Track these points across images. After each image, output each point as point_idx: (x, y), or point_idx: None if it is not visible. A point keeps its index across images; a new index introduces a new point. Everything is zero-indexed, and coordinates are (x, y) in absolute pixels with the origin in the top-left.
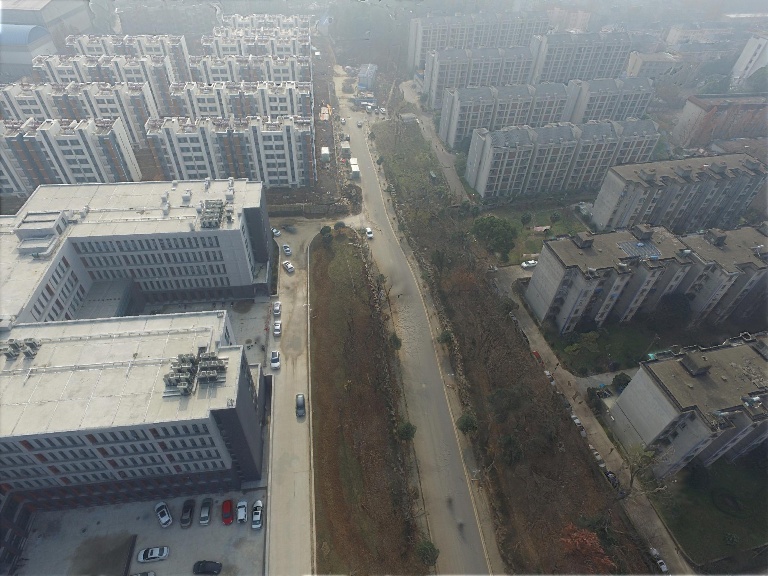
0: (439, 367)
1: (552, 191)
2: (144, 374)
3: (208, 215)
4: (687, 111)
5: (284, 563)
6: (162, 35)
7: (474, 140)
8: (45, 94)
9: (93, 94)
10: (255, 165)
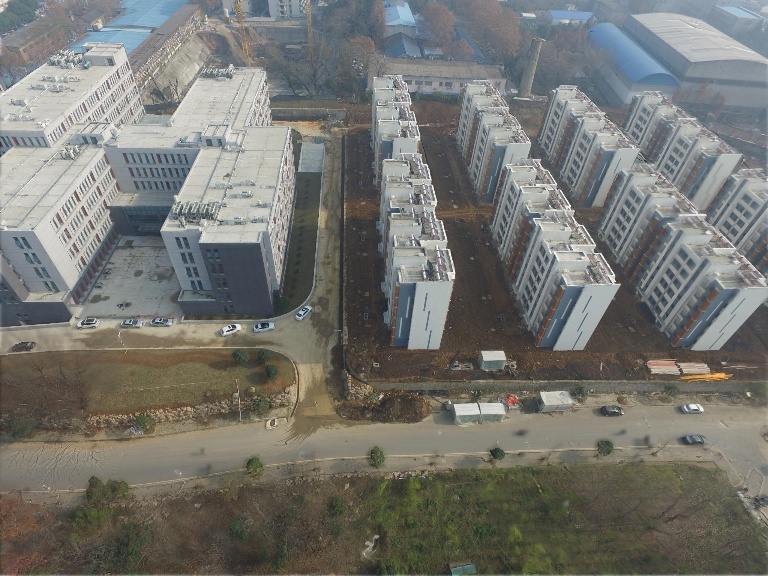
0: None
1: None
2: None
3: (185, 205)
4: None
5: None
6: (715, 138)
7: None
8: (475, 102)
9: (486, 122)
10: None
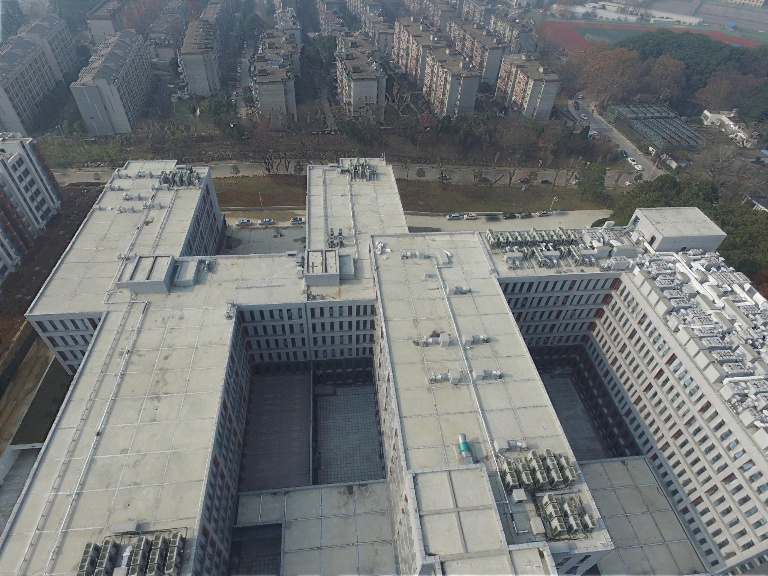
0: (315, 163)
1: (143, 106)
2: (359, 190)
3: (187, 175)
4: (95, 28)
5: (424, 224)
6: None
7: (80, 95)
8: None
9: None
10: (24, 208)
